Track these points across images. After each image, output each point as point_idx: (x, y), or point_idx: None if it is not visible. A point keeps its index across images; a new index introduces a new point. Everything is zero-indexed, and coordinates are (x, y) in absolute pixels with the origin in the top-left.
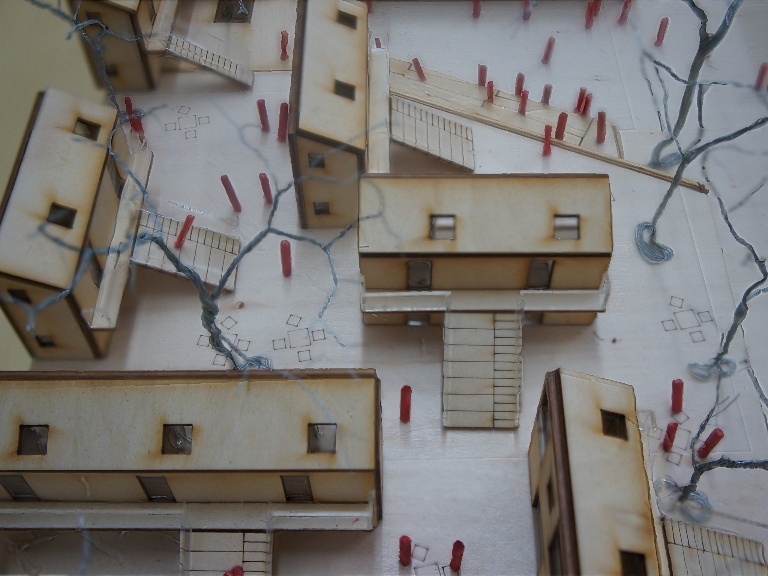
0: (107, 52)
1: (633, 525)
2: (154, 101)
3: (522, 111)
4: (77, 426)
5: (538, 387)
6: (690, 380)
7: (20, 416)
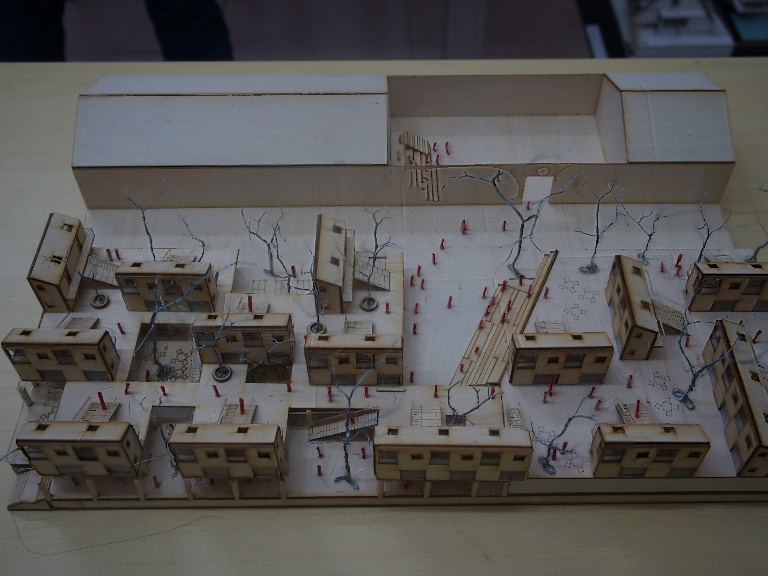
0: None
1: (744, 265)
2: None
3: None
4: (761, 405)
5: None
6: (648, 266)
7: (764, 421)
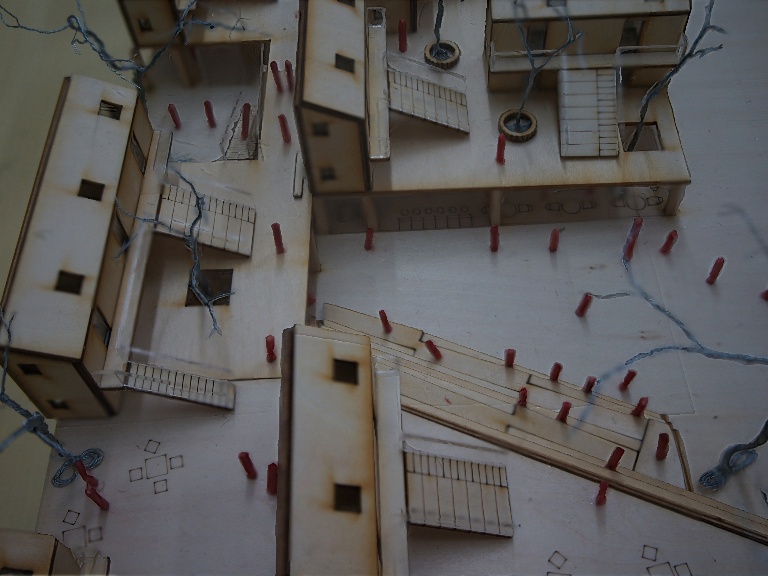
0: (51, 393)
1: None
2: (115, 434)
3: (563, 418)
4: None
5: None
6: None
7: None
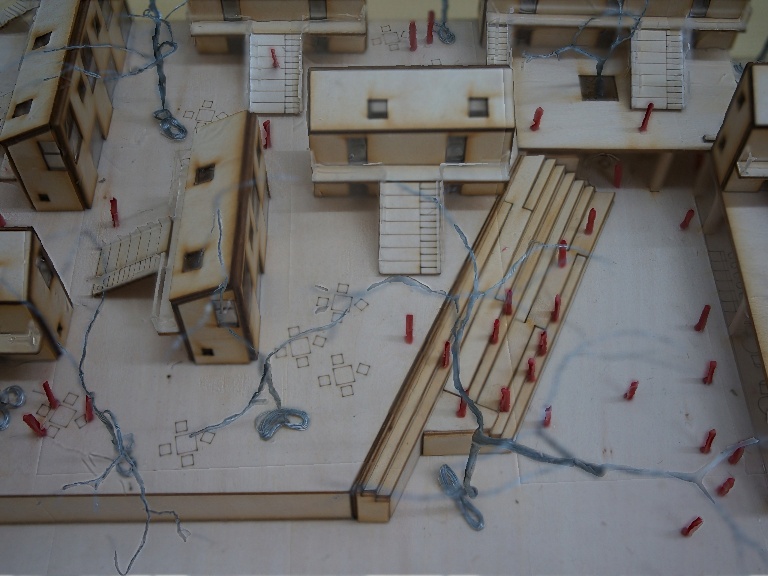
0: None
1: None
2: (467, 48)
3: (493, 336)
4: None
5: (130, 314)
6: None
7: None
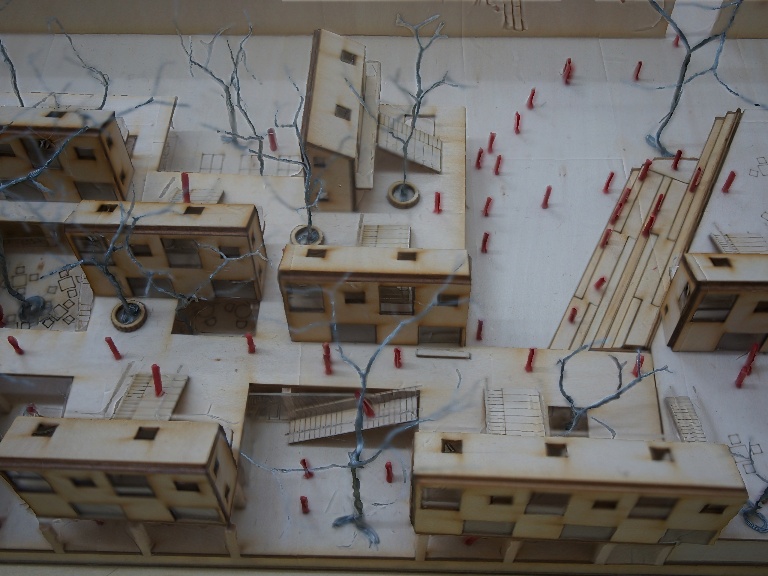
0: None
1: None
2: None
3: (658, 210)
4: None
5: None
6: None
7: None
